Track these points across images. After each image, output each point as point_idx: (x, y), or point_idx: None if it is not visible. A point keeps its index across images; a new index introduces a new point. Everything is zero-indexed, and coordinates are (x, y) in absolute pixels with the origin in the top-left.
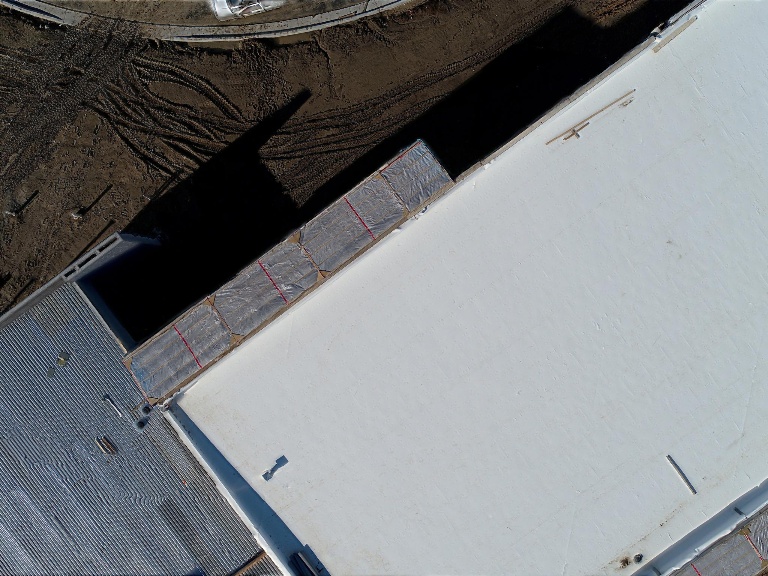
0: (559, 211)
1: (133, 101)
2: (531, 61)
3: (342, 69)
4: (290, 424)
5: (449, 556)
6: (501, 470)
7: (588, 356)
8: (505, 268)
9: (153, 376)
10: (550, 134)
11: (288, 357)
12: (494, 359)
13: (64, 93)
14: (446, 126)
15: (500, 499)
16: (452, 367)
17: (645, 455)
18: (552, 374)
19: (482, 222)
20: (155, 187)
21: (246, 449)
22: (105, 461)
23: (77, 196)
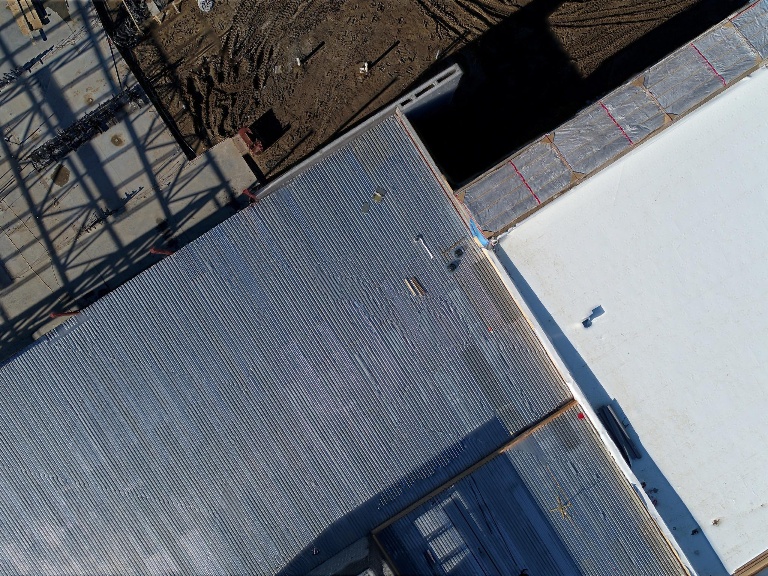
0: None
1: None
2: None
3: None
4: (610, 274)
5: (756, 421)
6: None
7: None
8: None
9: (488, 210)
10: None
11: (614, 205)
12: None
13: None
14: (739, 5)
15: None
16: None
17: None
18: None
19: None
20: (442, 46)
21: (564, 296)
22: (404, 306)
23: (363, 50)
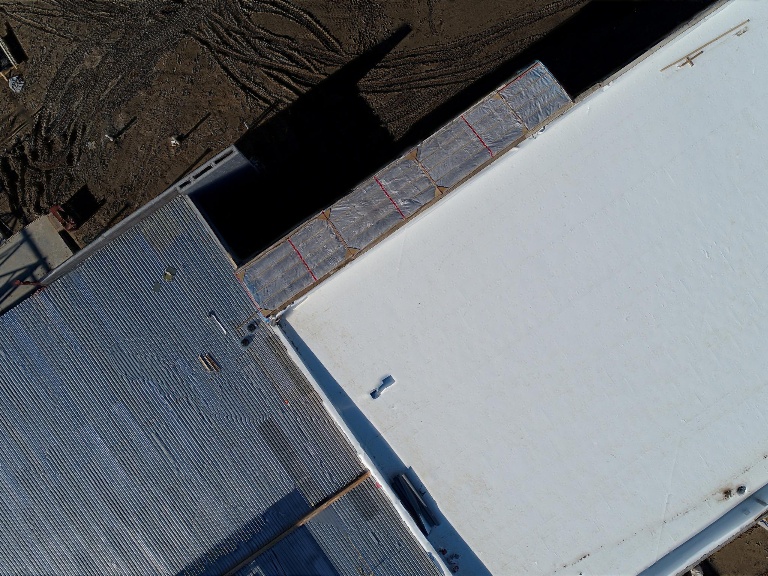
0: (671, 138)
1: (234, 31)
2: (629, 3)
3: (442, 6)
4: (398, 344)
5: (553, 483)
6: (607, 396)
7: (696, 284)
8: (617, 193)
9: (266, 288)
10: (664, 61)
11: (398, 276)
12: (603, 284)
13: (166, 21)
14: None
15: (605, 426)
16: (561, 291)
17: (751, 385)
18: (660, 301)
19: (595, 146)
20: (253, 116)
21: (353, 368)
22: (205, 381)
23: (175, 123)
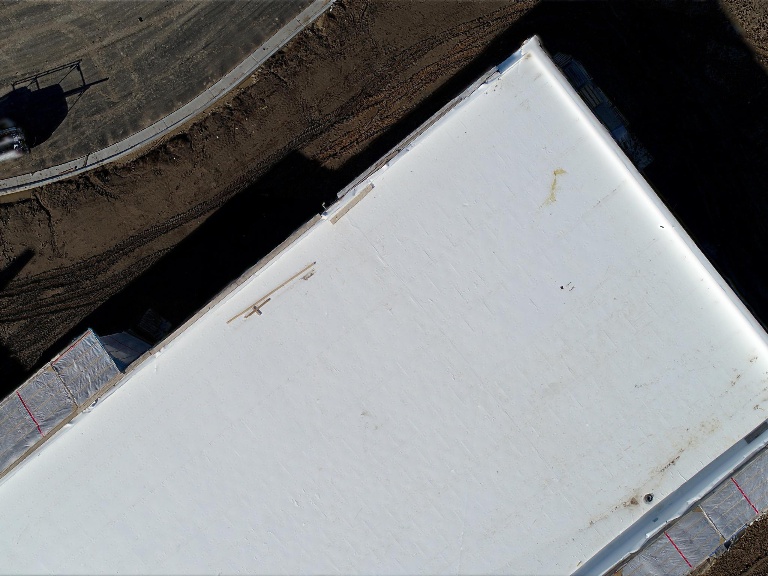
0: (246, 389)
1: None
2: (257, 209)
3: (64, 227)
4: None
5: None
6: None
7: (288, 534)
8: (195, 450)
9: None
10: (230, 312)
11: None
12: (191, 542)
13: None
14: (174, 279)
15: None
16: (148, 553)
17: None
18: (253, 554)
19: (167, 405)
20: None
21: None
22: None
23: None
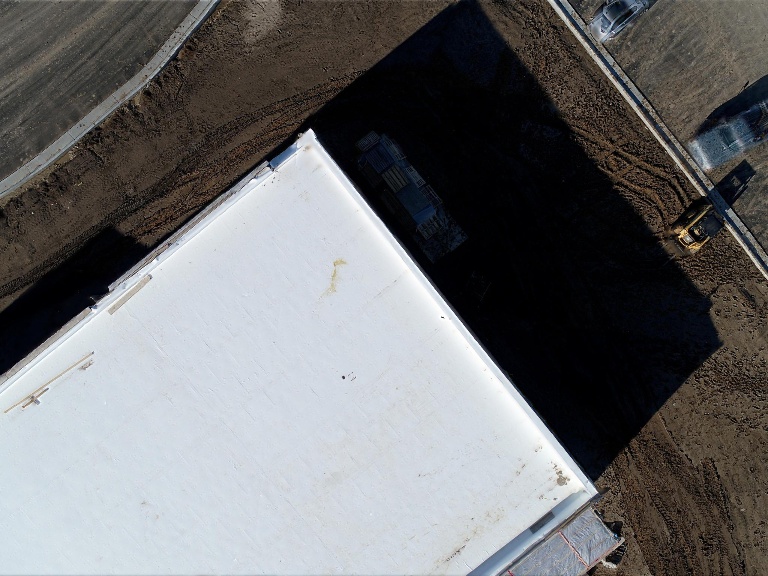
0: (25, 478)
1: None
2: (71, 285)
3: None
4: None
5: None
6: None
7: None
8: None
9: None
10: (8, 402)
11: None
12: None
13: None
14: None
15: None
16: None
17: None
18: None
19: None
20: None
21: None
22: None
23: None
